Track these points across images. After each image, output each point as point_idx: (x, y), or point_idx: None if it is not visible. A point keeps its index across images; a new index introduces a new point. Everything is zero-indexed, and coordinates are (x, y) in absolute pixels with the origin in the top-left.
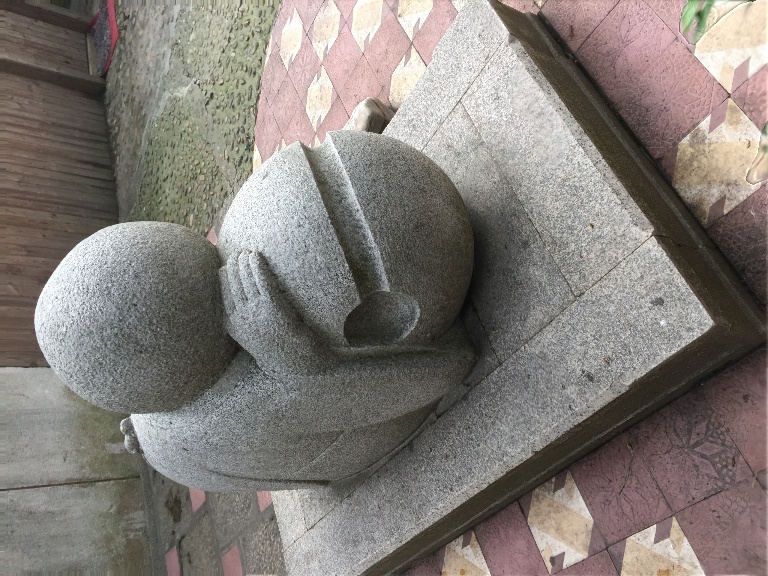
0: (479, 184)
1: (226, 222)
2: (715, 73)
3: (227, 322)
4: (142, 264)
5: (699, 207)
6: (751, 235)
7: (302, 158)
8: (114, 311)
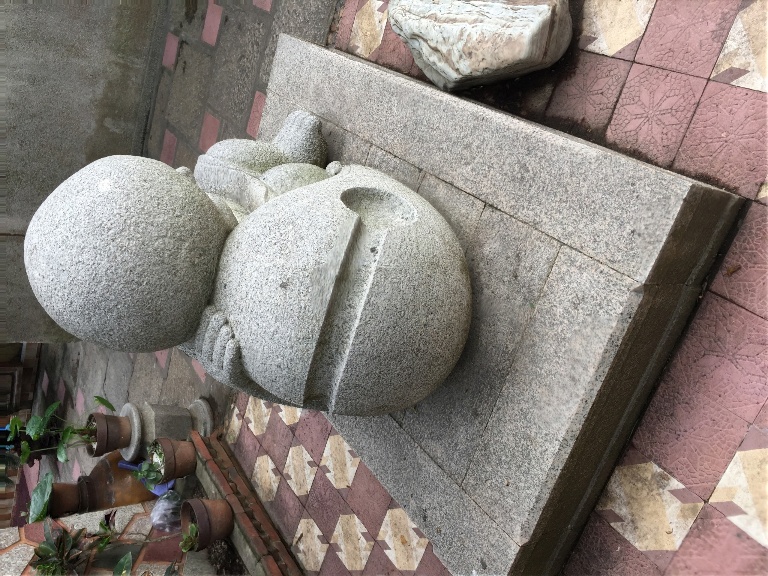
0: (500, 325)
1: (236, 260)
2: (724, 481)
3: (193, 343)
4: (128, 309)
5: (608, 499)
6: (603, 551)
7: (323, 306)
8: (90, 330)
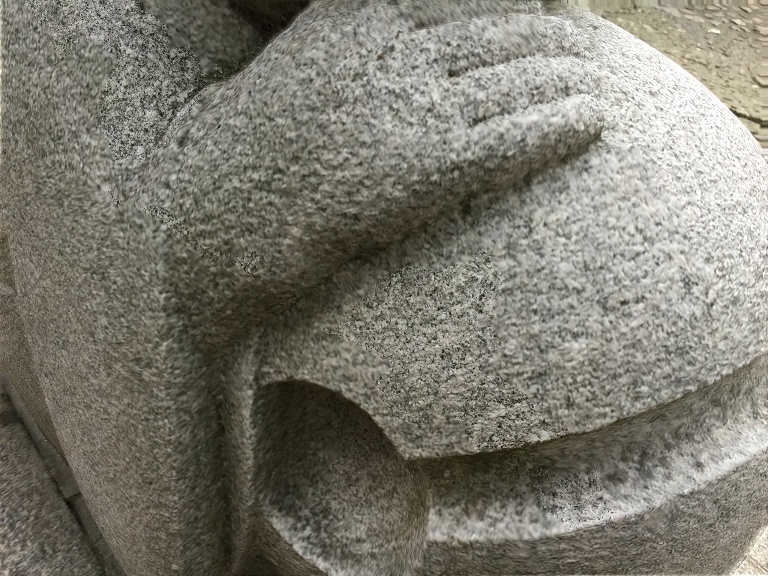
0: None
1: None
2: None
3: None
4: None
5: None
6: None
7: None
8: None
